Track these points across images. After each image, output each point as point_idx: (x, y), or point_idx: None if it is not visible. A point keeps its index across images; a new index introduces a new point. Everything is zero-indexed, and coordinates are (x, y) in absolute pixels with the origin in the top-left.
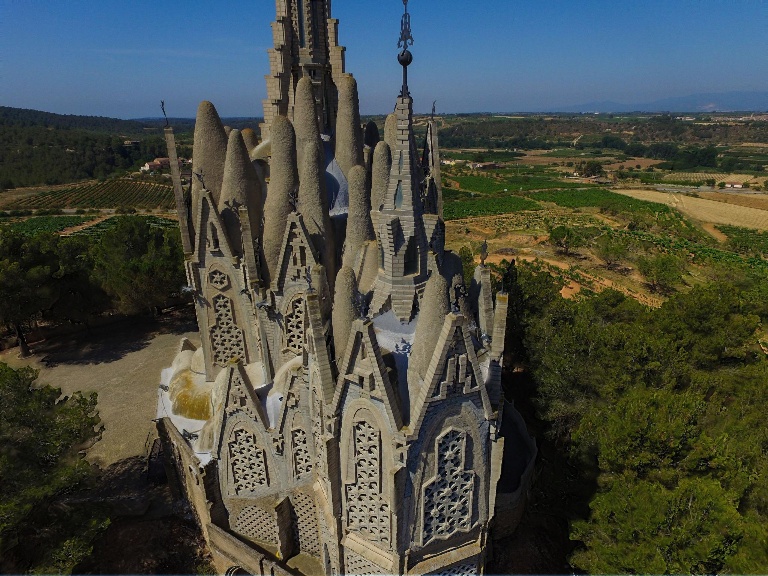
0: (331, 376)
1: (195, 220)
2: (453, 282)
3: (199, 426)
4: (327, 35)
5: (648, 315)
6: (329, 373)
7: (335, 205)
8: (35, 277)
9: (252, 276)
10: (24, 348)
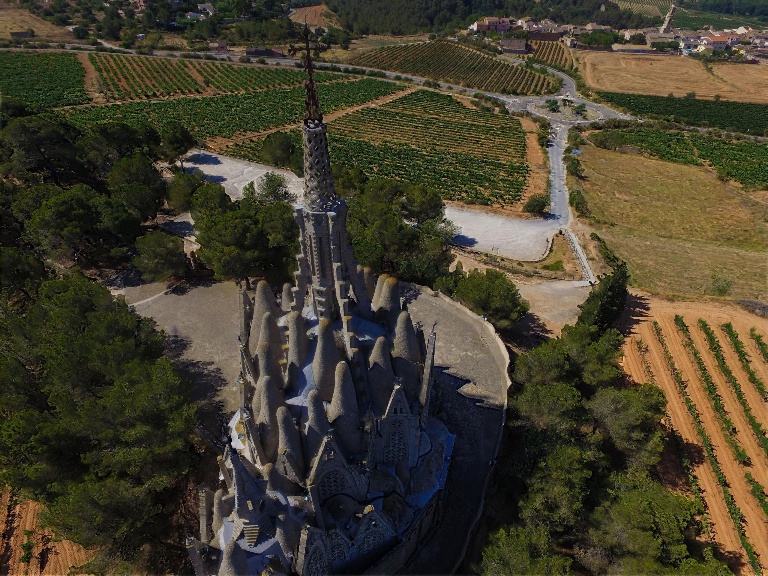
0: (206, 532)
1: (250, 345)
2: (277, 530)
3: (239, 446)
4: (333, 271)
5: (646, 567)
6: (205, 531)
7: (301, 395)
8: (248, 258)
9: (242, 417)
10: (248, 285)
